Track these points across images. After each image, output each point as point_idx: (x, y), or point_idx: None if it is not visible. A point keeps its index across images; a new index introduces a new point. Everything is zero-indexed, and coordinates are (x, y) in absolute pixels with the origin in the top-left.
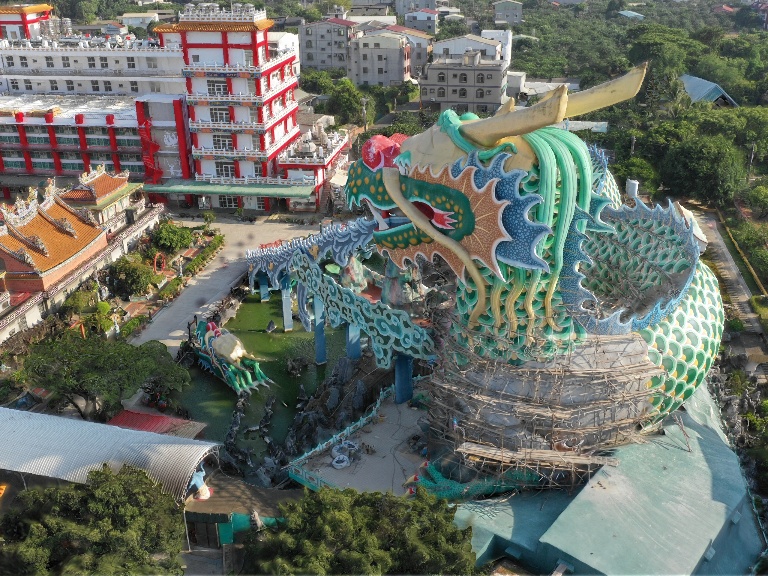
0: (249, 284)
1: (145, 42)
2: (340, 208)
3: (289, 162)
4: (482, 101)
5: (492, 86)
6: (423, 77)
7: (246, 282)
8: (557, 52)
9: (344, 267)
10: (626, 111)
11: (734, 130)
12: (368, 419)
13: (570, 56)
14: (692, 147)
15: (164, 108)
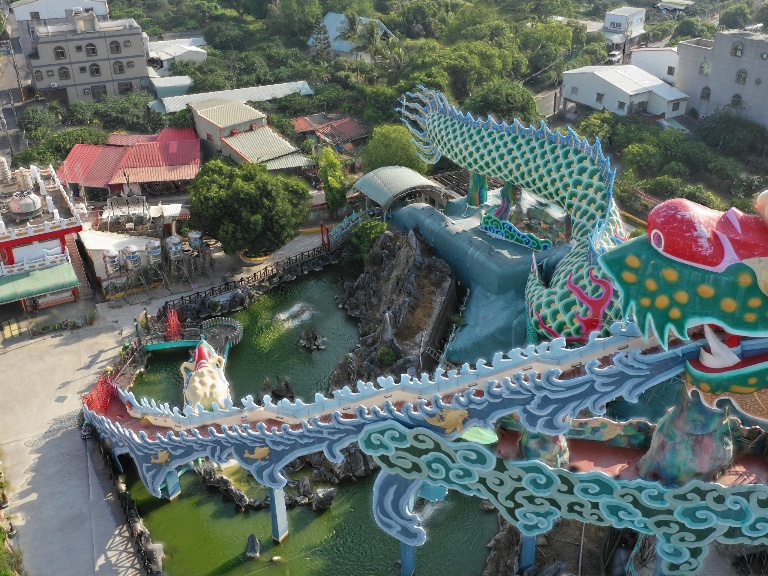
0: (117, 476)
1: None
2: (119, 284)
3: (15, 236)
4: (123, 77)
5: (133, 56)
6: (27, 56)
7: (114, 476)
8: (115, 1)
9: (552, 435)
10: (304, 64)
11: (474, 70)
12: None
13: (135, 5)
14: (499, 98)
15: None
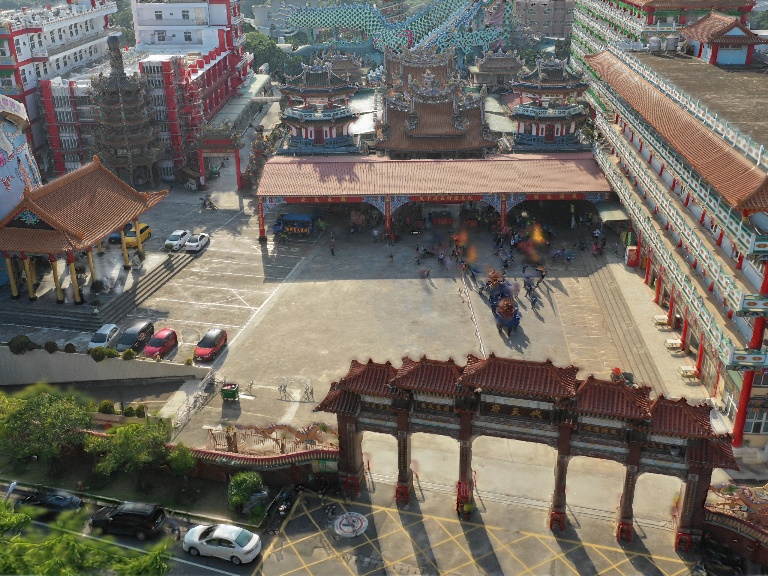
0: None
1: (78, 5)
2: None
3: None
4: None
5: None
6: None
7: None
8: None
9: None
10: None
11: None
12: None
13: None
14: None
15: None
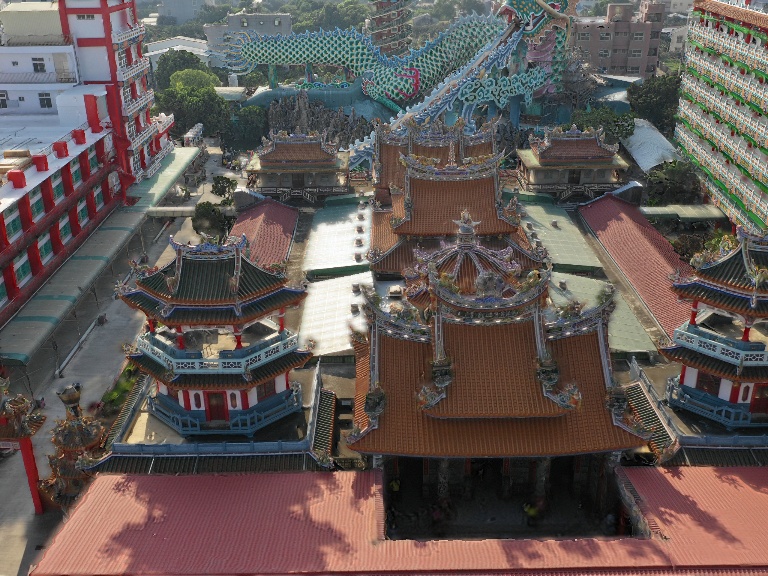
0: None
1: None
2: None
3: None
4: None
5: None
6: None
7: None
8: None
9: None
10: None
11: None
12: (542, 130)
13: None
14: None
15: (101, 102)
